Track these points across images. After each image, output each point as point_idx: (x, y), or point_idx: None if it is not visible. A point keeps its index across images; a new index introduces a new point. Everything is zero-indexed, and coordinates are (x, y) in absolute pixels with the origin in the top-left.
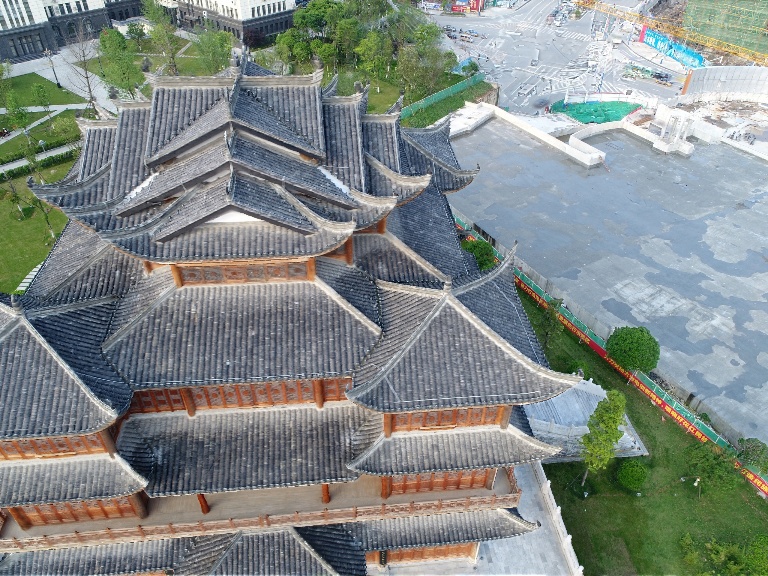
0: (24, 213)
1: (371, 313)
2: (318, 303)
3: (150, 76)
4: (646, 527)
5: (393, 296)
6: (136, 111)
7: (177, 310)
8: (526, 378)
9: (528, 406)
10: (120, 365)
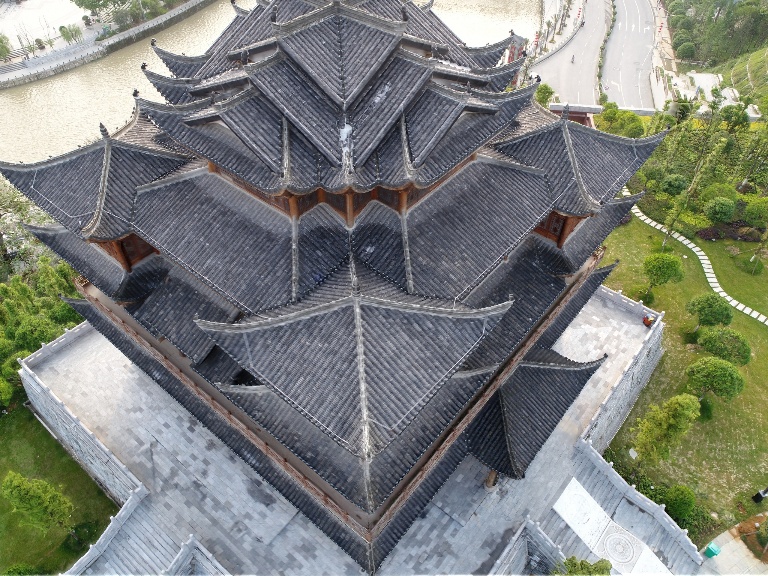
0: None
1: (174, 143)
2: None
3: None
4: (3, 548)
5: None
6: None
7: None
8: None
9: (152, 532)
10: None
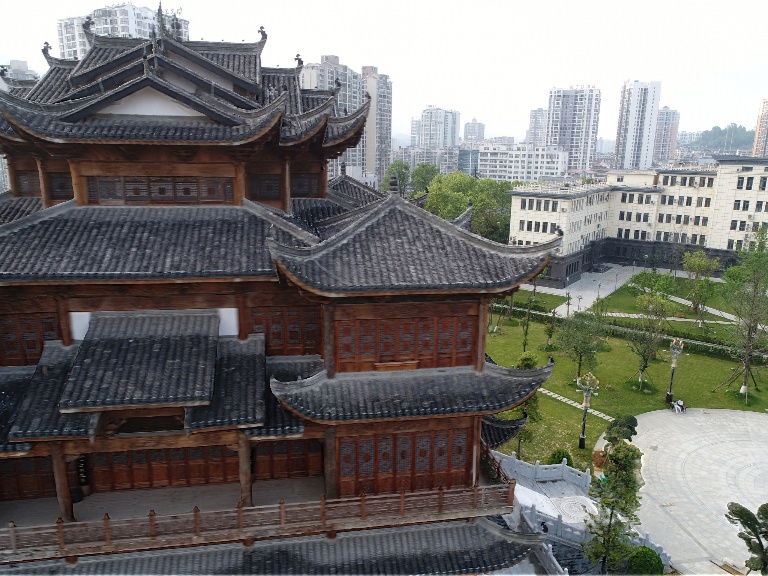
0: (548, 347)
1: None
2: None
3: None
4: None
5: None
6: None
7: None
8: None
9: None
10: None
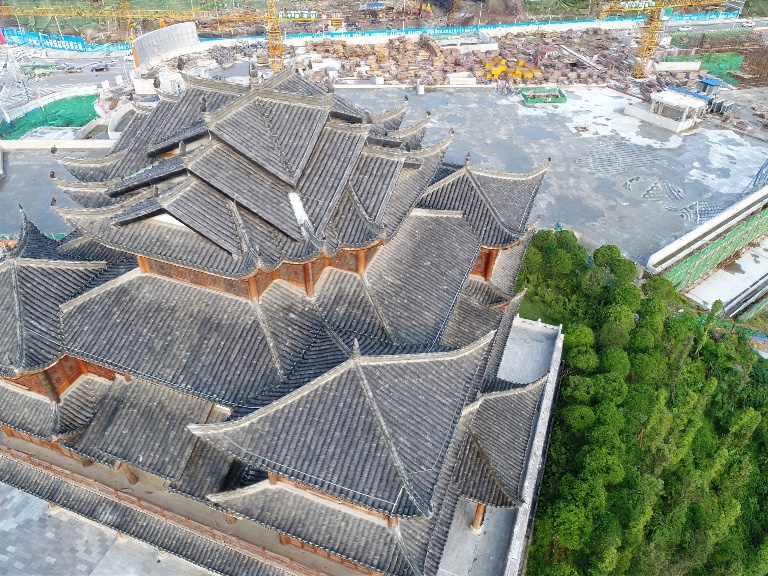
0: None
1: None
2: (424, 223)
3: (207, 115)
4: None
5: (431, 197)
6: (205, 159)
7: (384, 287)
8: (526, 185)
9: None
10: (415, 341)
